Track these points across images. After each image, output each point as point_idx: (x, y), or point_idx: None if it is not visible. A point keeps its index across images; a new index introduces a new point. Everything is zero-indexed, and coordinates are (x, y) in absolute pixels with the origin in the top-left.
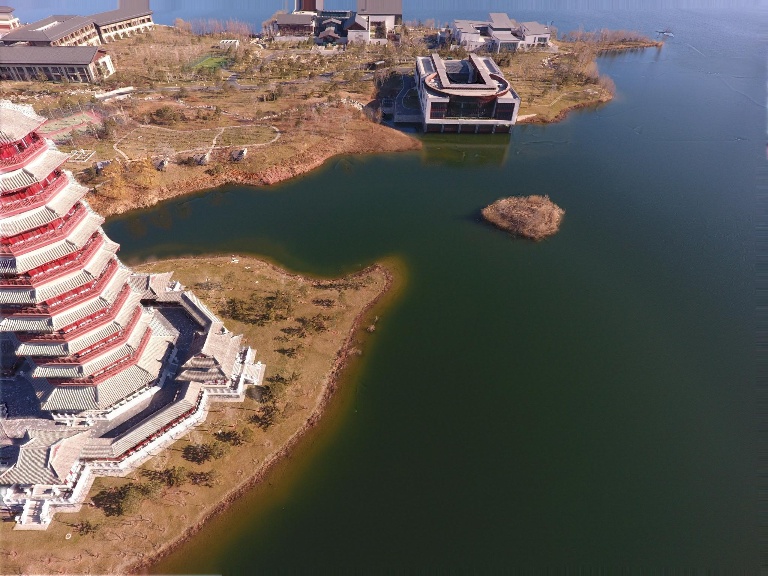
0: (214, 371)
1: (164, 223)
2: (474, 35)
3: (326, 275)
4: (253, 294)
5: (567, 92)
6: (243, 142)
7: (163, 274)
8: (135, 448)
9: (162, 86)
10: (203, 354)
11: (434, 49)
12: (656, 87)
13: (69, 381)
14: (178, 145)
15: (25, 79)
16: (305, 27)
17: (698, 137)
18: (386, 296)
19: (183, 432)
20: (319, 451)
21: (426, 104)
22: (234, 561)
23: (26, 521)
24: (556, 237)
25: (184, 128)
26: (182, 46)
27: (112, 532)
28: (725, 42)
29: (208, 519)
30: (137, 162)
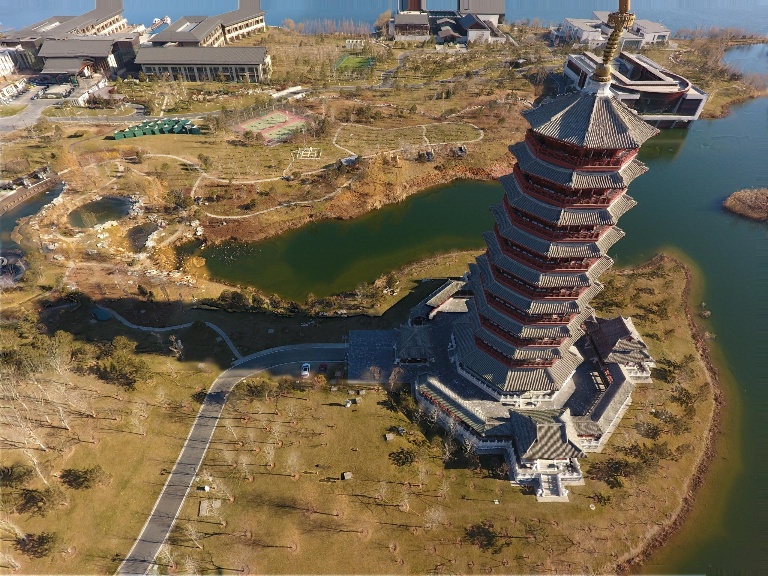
0: (636, 353)
1: (395, 218)
2: (595, 33)
3: (618, 265)
4: None
5: (718, 88)
6: (454, 139)
7: None
8: None
9: None
10: (631, 337)
11: (554, 47)
12: None
13: (530, 363)
14: (395, 142)
15: (193, 79)
16: (422, 26)
17: None
18: (693, 284)
19: (621, 411)
20: (743, 428)
21: None
22: (740, 528)
23: (545, 494)
24: None
25: (386, 126)
26: (308, 46)
27: (624, 503)
28: None
29: (694, 490)
30: (369, 159)
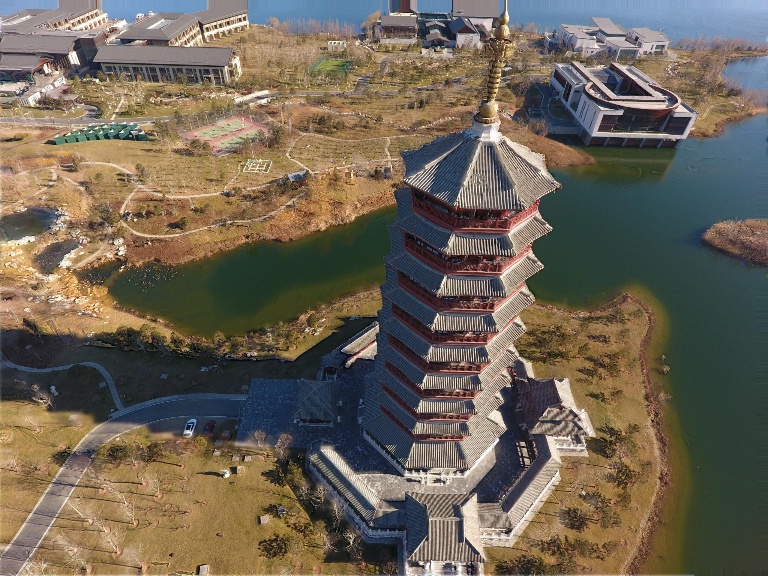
0: (568, 424)
1: (347, 239)
2: (590, 41)
3: (576, 305)
4: (537, 329)
5: (714, 104)
6: None
7: None
8: None
9: (296, 90)
10: (562, 406)
11: (546, 55)
12: None
13: (436, 436)
14: (353, 156)
15: (155, 80)
16: (409, 29)
17: None
18: (656, 331)
19: (545, 493)
20: (689, 516)
21: (594, 116)
22: None
23: None
24: None
25: (348, 137)
26: (288, 47)
27: None
28: None
29: None
30: (321, 174)
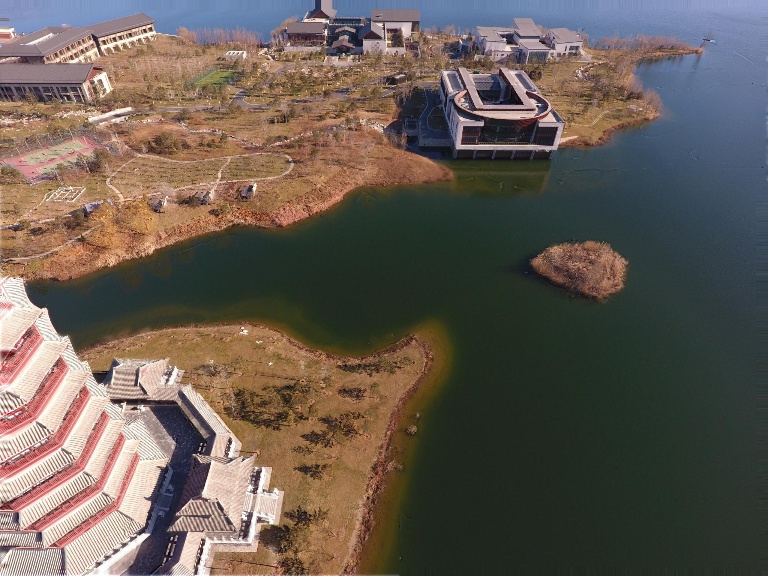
0: (218, 517)
1: (163, 271)
2: (500, 44)
3: (353, 350)
4: (267, 387)
5: (609, 109)
6: (252, 175)
7: (156, 362)
8: None
9: (163, 106)
10: (204, 498)
11: (456, 59)
12: (705, 101)
13: None
14: (179, 179)
15: None
16: (317, 36)
17: (765, 163)
18: (427, 381)
19: None
20: None
21: (457, 128)
22: None
23: None
24: (622, 295)
25: (186, 158)
26: (186, 58)
27: None
28: None
29: None
30: (132, 201)
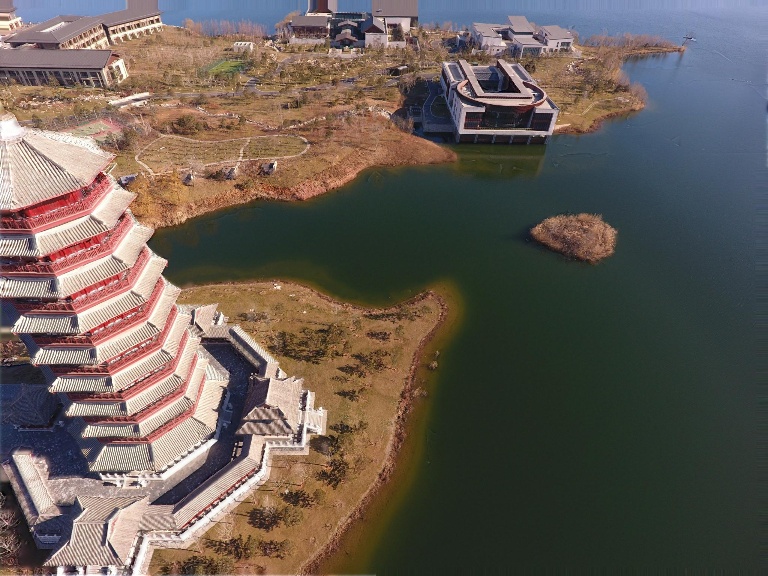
0: (278, 423)
1: (191, 241)
2: (496, 39)
3: (375, 303)
4: (305, 328)
5: (598, 100)
6: (272, 154)
7: (208, 306)
8: (197, 515)
9: (179, 92)
10: (267, 405)
11: (454, 53)
12: (687, 95)
13: (121, 439)
14: (204, 157)
15: (34, 83)
16: (320, 29)
17: (739, 149)
18: (443, 327)
19: (246, 493)
20: (395, 512)
21: (460, 114)
22: None
23: None
24: (612, 259)
25: (208, 138)
26: (194, 48)
27: None
28: (748, 48)
29: None
30: (162, 176)
